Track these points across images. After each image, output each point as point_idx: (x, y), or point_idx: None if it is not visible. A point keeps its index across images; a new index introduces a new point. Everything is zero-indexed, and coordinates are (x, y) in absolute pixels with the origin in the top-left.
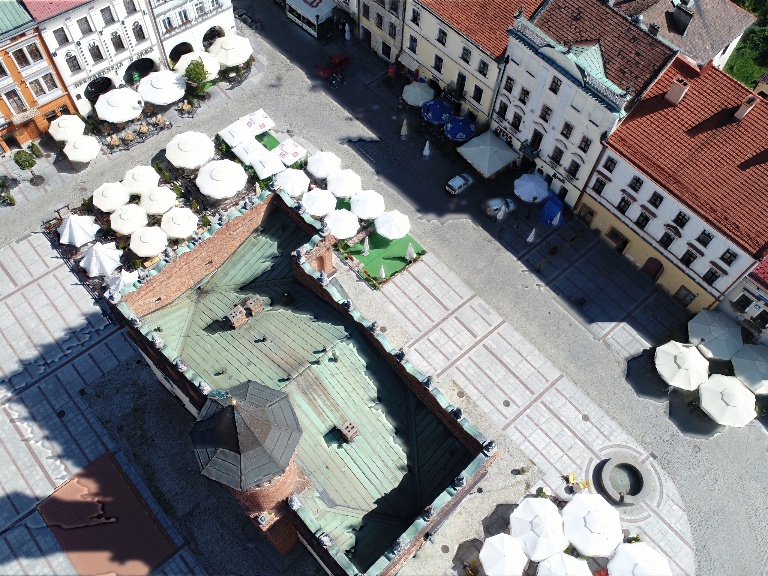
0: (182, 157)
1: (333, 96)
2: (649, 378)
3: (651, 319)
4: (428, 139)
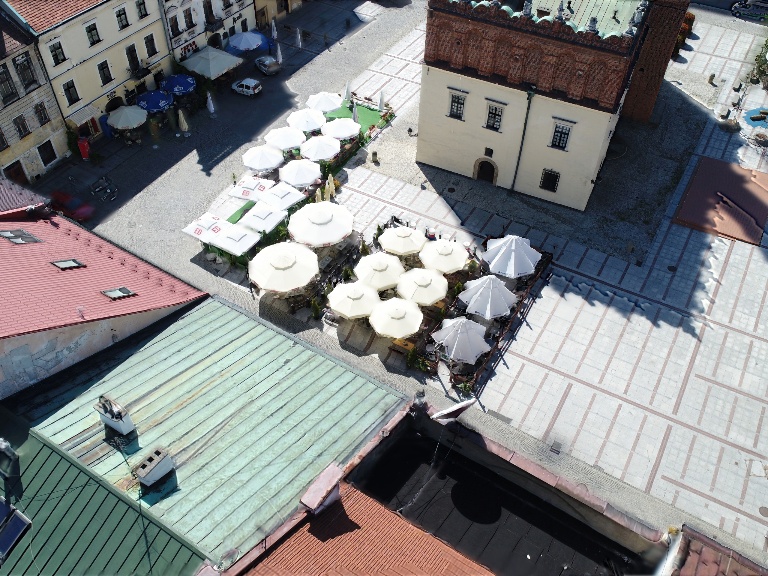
0: (305, 262)
1: (127, 199)
2: (395, 0)
3: (345, 2)
4: (186, 118)
